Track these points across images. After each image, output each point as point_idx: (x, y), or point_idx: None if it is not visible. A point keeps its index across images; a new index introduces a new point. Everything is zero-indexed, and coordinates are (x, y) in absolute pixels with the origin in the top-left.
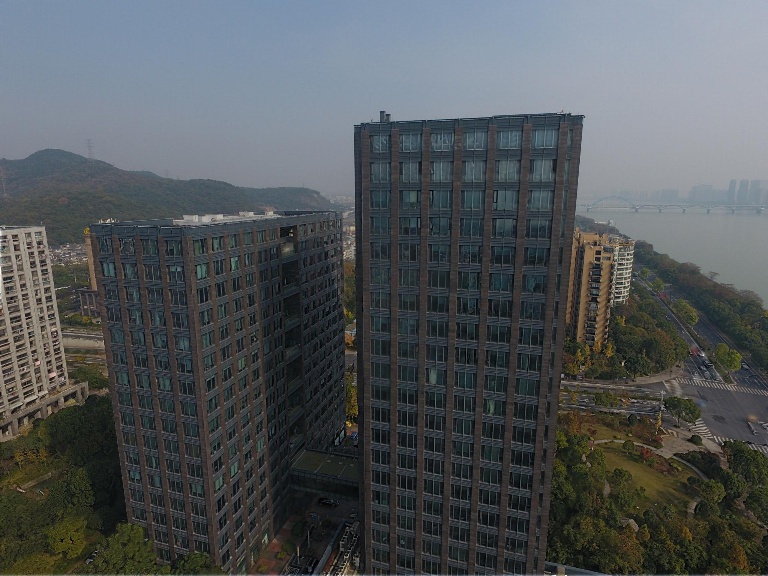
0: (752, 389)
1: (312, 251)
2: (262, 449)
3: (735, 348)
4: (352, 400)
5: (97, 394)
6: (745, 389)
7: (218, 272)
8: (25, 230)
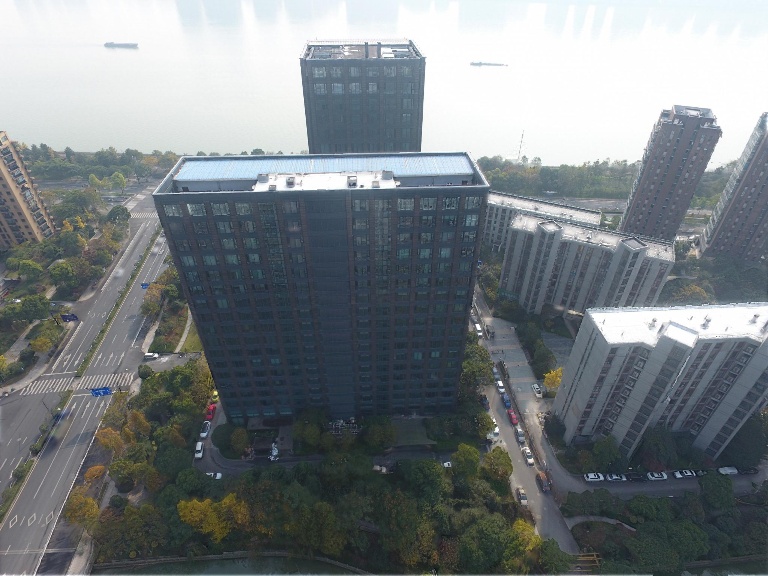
0: (144, 190)
1: None
2: None
3: (56, 181)
4: None
5: None
6: (144, 192)
7: None
8: None
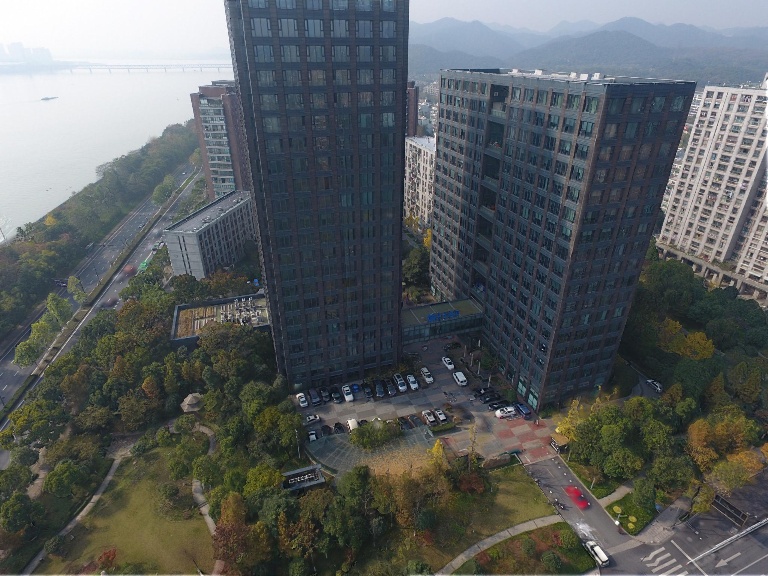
0: None
1: (526, 125)
2: None
3: None
4: None
5: None
6: None
7: None
8: None
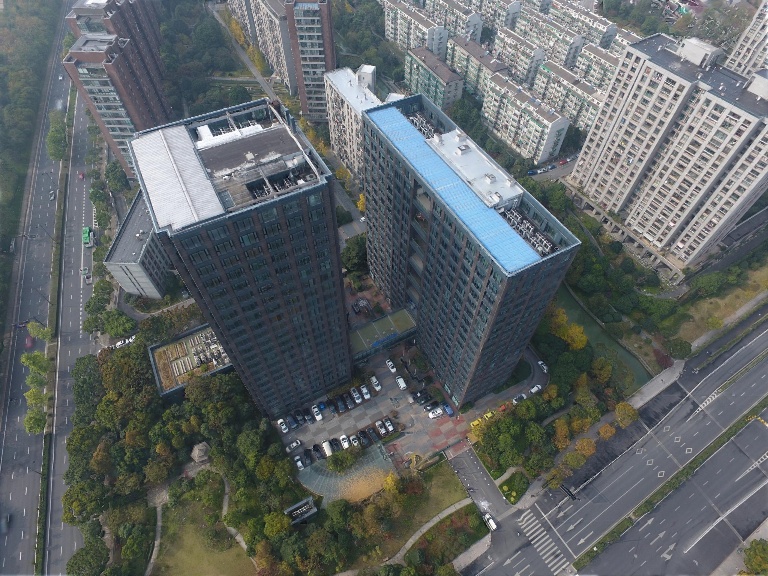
0: None
1: (447, 240)
2: (389, 265)
3: None
4: None
5: (682, 291)
6: None
7: None
8: None
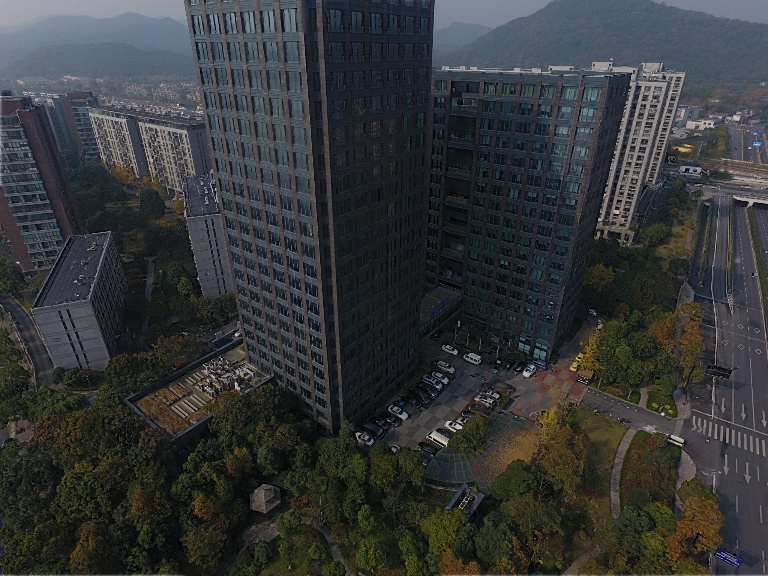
0: None
1: (508, 116)
2: None
3: None
4: None
5: None
6: None
7: None
8: (647, 84)
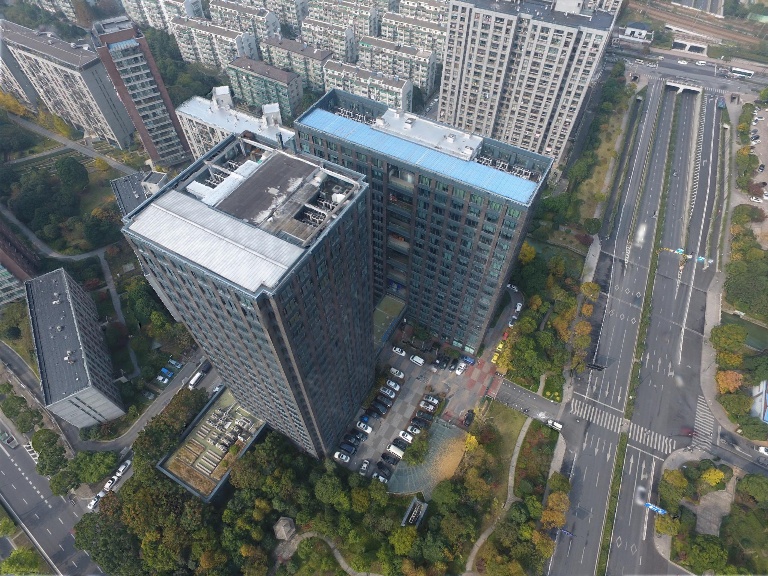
0: None
1: (441, 205)
2: None
3: None
4: (505, 353)
5: (564, 185)
6: None
7: (320, 156)
8: (589, 30)
